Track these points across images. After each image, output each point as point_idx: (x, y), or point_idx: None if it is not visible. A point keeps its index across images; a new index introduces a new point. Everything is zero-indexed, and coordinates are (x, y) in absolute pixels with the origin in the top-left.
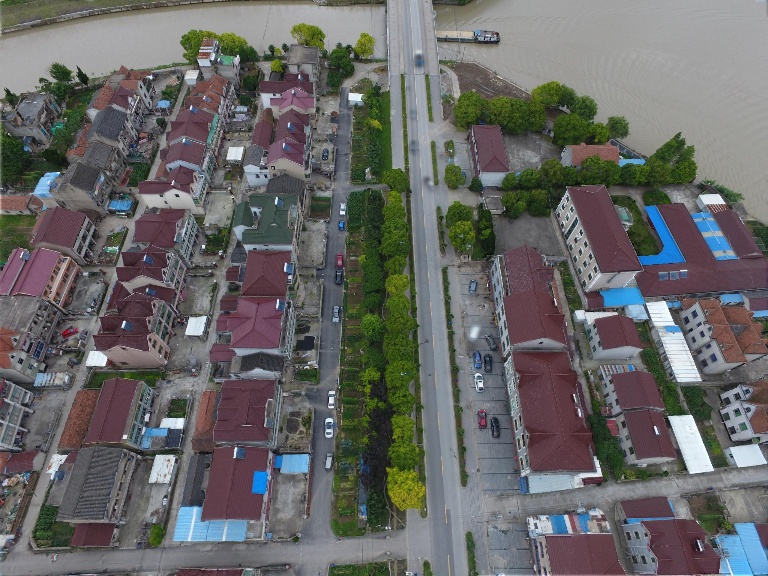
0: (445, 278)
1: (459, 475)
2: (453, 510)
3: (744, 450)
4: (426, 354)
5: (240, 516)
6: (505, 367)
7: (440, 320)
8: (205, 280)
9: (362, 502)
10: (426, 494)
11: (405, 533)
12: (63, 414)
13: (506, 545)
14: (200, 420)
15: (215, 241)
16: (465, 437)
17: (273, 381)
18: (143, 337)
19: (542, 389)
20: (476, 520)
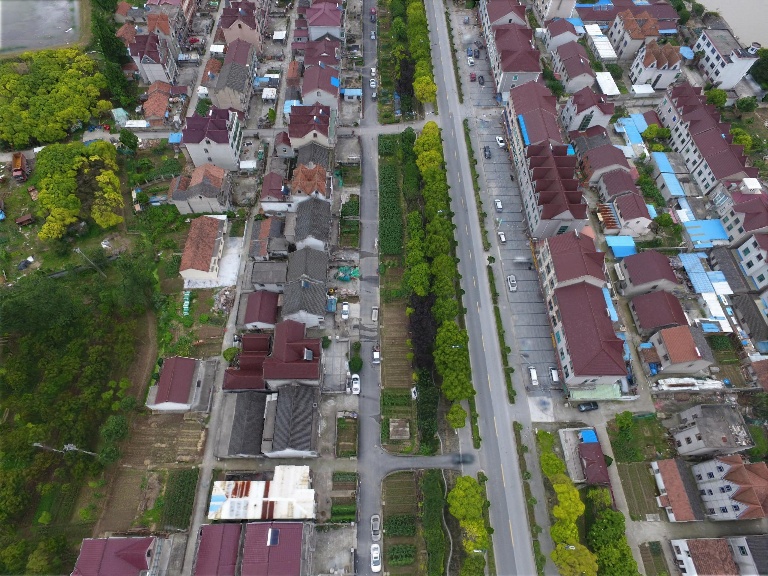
0: (447, 16)
1: (458, 99)
2: (455, 113)
3: (641, 86)
4: (435, 50)
5: (326, 90)
6: (488, 47)
7: (444, 35)
8: (281, 19)
9: (397, 109)
10: (437, 106)
11: (425, 121)
12: (198, 76)
13: (488, 126)
14: (290, 73)
15: (285, 0)
16: (462, 85)
17: (338, 41)
18: (253, 18)
19: (510, 35)
20: (469, 117)
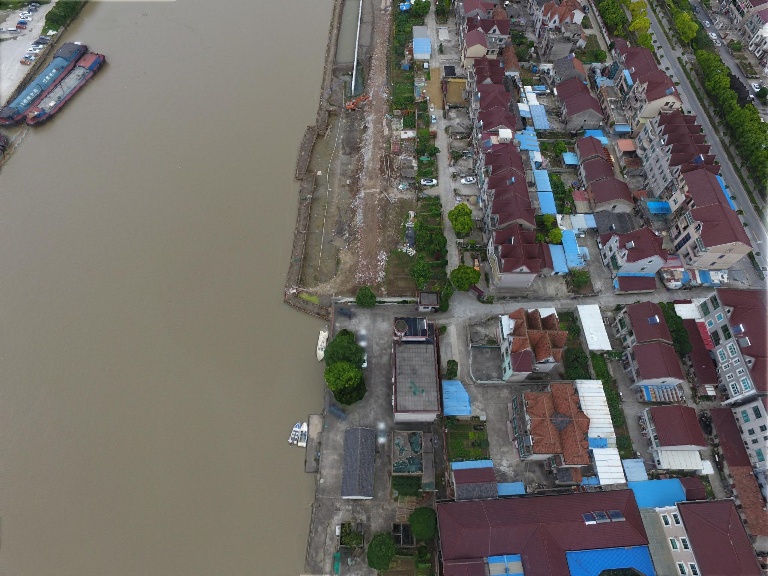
0: None
1: None
2: None
3: None
4: None
5: None
6: None
7: None
8: None
9: None
10: None
11: None
12: None
13: (732, 273)
14: None
15: None
16: None
17: None
18: None
19: None
20: (759, 288)
